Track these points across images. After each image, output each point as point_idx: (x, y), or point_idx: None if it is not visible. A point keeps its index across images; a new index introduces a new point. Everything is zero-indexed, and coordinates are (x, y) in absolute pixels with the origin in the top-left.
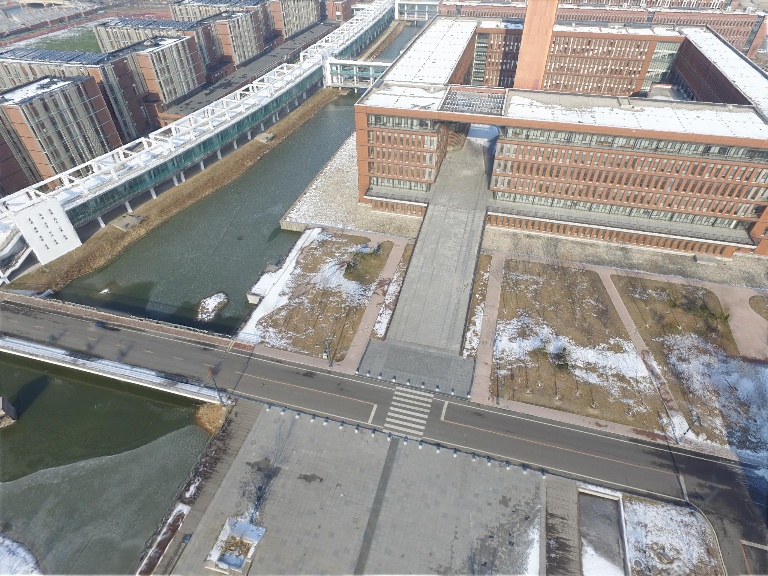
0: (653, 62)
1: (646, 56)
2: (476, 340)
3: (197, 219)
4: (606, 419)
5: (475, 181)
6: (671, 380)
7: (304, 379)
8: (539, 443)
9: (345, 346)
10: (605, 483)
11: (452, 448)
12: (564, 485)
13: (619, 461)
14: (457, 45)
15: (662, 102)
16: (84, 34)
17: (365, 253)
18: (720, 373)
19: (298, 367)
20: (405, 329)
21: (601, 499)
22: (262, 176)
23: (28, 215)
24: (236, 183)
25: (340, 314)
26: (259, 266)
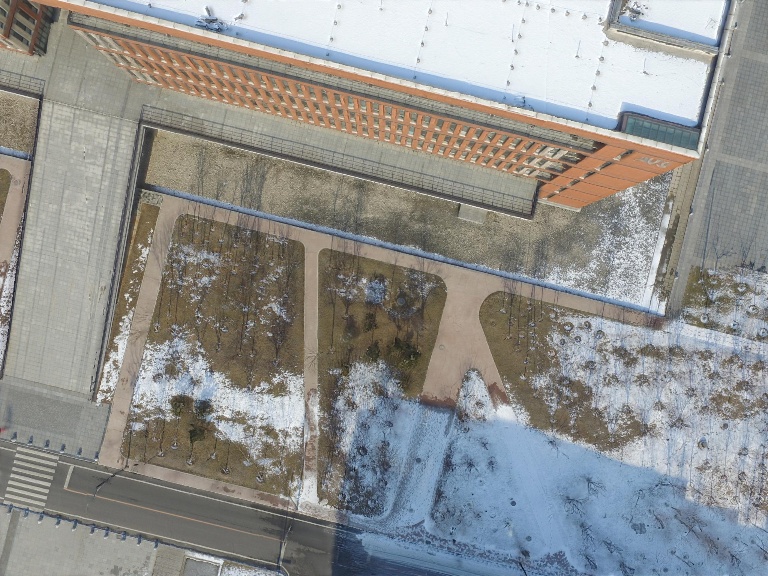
0: None
1: None
2: (114, 377)
3: None
4: (236, 483)
5: None
6: (325, 432)
7: None
8: (160, 512)
9: None
10: (212, 551)
11: (73, 520)
12: (173, 555)
13: (233, 529)
14: None
15: None
16: None
17: None
18: (382, 424)
19: None
20: (26, 362)
21: (206, 562)
22: None
23: None
24: None
25: None
26: None
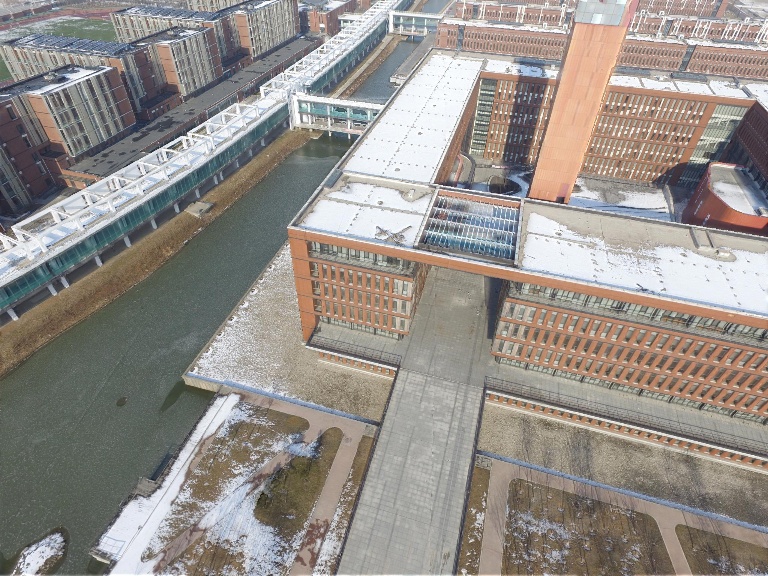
0: (709, 128)
1: (700, 121)
2: None
3: (69, 358)
4: None
5: (470, 320)
6: None
7: None
8: None
9: None
10: None
11: None
12: None
13: None
14: (454, 102)
15: (759, 240)
16: None
17: (296, 456)
18: None
19: None
20: None
21: None
22: (182, 276)
23: None
24: (143, 288)
25: None
26: (134, 468)
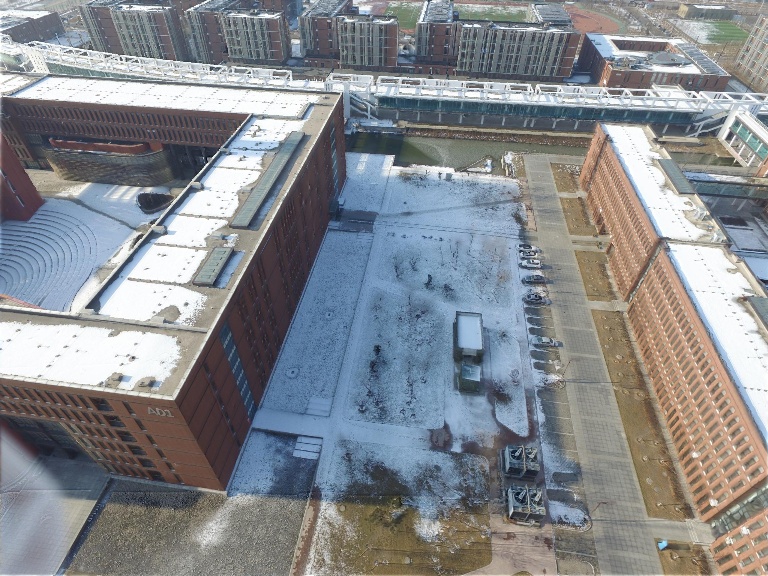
0: None
1: None
2: None
3: None
4: None
5: None
6: None
7: None
8: None
9: None
10: None
11: None
12: None
13: None
14: (163, 105)
15: None
16: (480, 12)
17: None
18: None
19: None
20: None
21: None
22: None
23: (31, 53)
24: None
25: None
26: None
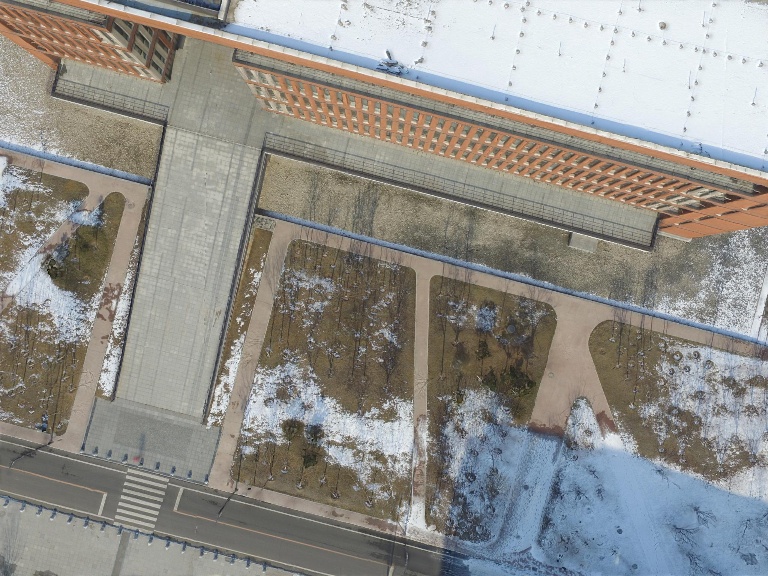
0: None
1: None
2: (225, 400)
3: None
4: (344, 508)
5: None
6: (434, 458)
7: (23, 461)
8: (269, 535)
9: (65, 412)
10: (320, 575)
11: (182, 542)
12: None
13: (341, 553)
14: None
15: None
16: None
17: (81, 225)
18: (491, 451)
19: (14, 443)
20: (138, 385)
21: None
22: None
23: None
24: None
25: (54, 358)
26: None
